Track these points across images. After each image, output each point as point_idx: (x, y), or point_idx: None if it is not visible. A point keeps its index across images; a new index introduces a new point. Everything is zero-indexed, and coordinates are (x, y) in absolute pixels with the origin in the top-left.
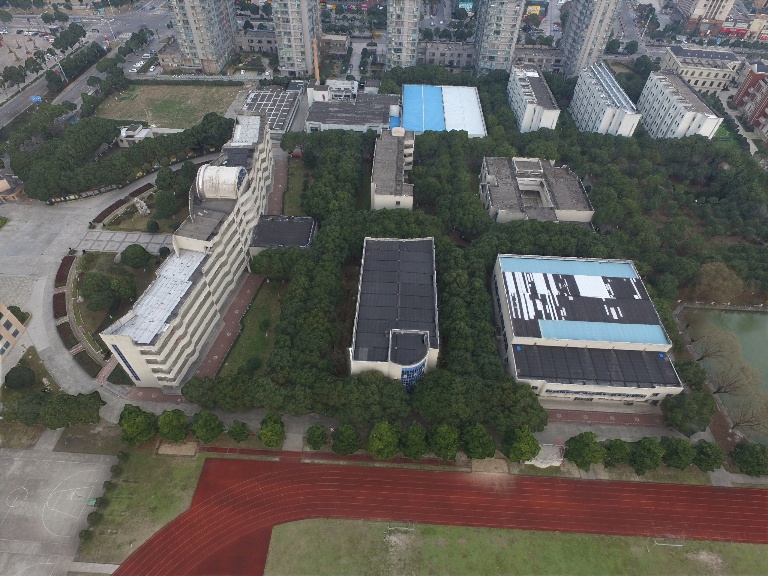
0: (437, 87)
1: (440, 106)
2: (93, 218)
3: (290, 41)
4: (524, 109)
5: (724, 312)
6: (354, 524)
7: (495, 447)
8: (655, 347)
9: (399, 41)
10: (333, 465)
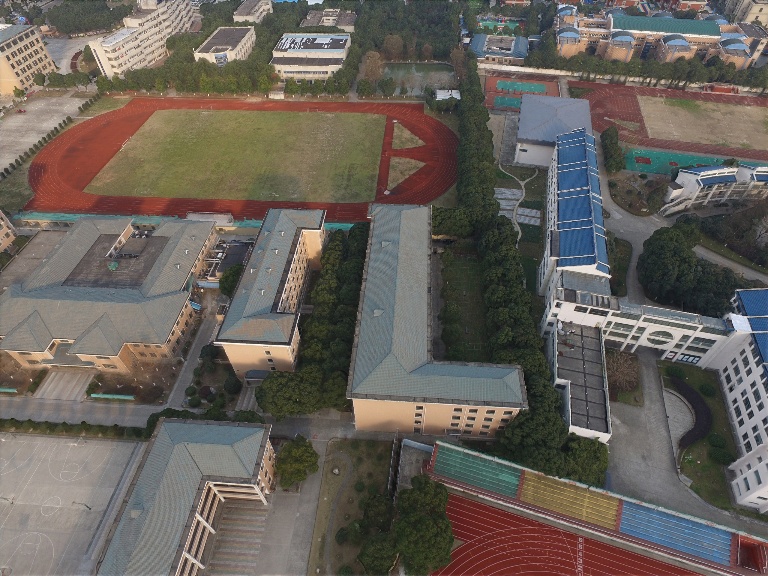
0: None
1: None
2: None
3: None
4: None
5: (416, 72)
6: (189, 110)
7: (254, 87)
8: (337, 55)
9: None
10: (186, 99)
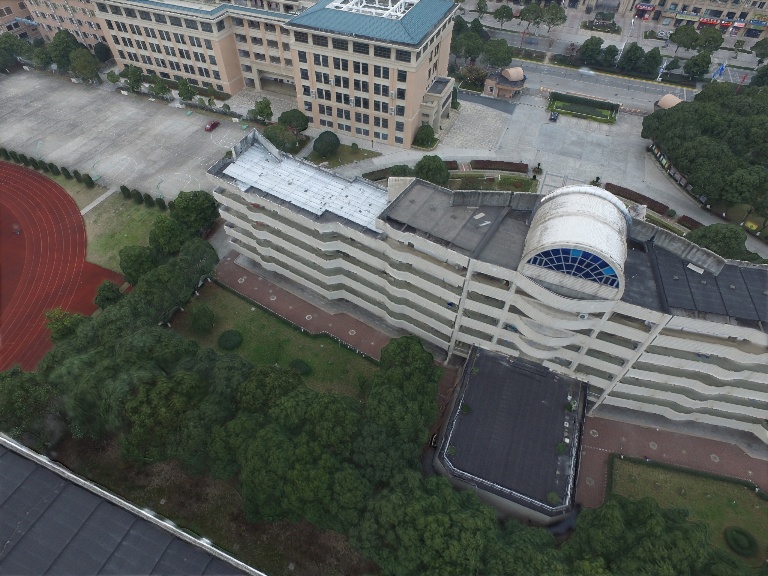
0: None
1: None
2: (617, 185)
3: None
4: None
5: None
6: None
7: None
8: None
9: None
10: None
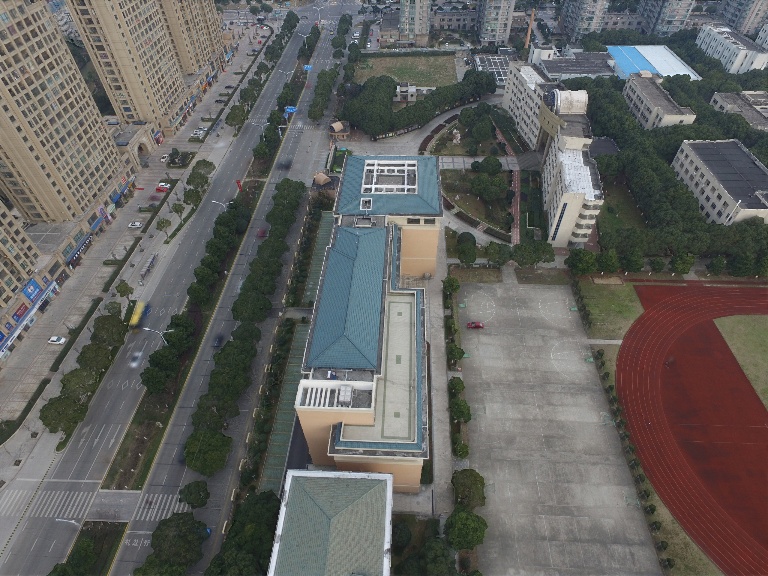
0: (631, 47)
1: (645, 60)
2: (416, 148)
3: (498, 14)
4: (735, 55)
5: None
6: None
7: None
8: None
9: (593, 10)
10: (729, 287)
